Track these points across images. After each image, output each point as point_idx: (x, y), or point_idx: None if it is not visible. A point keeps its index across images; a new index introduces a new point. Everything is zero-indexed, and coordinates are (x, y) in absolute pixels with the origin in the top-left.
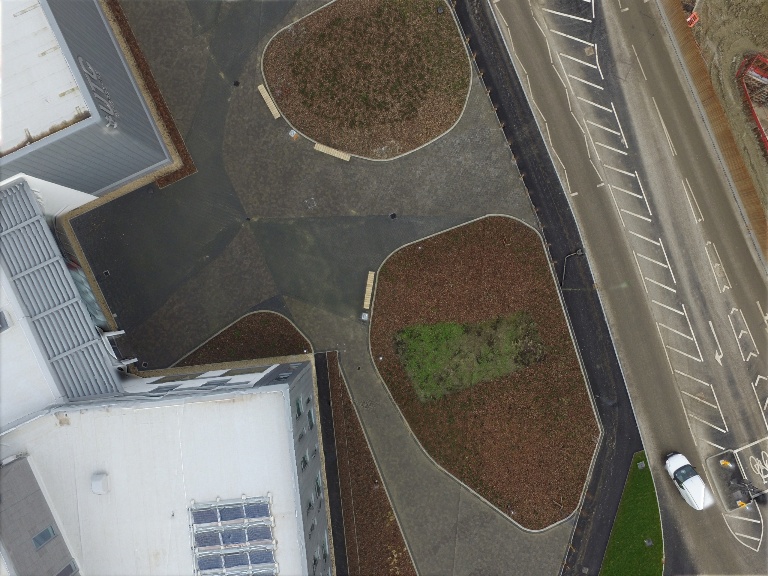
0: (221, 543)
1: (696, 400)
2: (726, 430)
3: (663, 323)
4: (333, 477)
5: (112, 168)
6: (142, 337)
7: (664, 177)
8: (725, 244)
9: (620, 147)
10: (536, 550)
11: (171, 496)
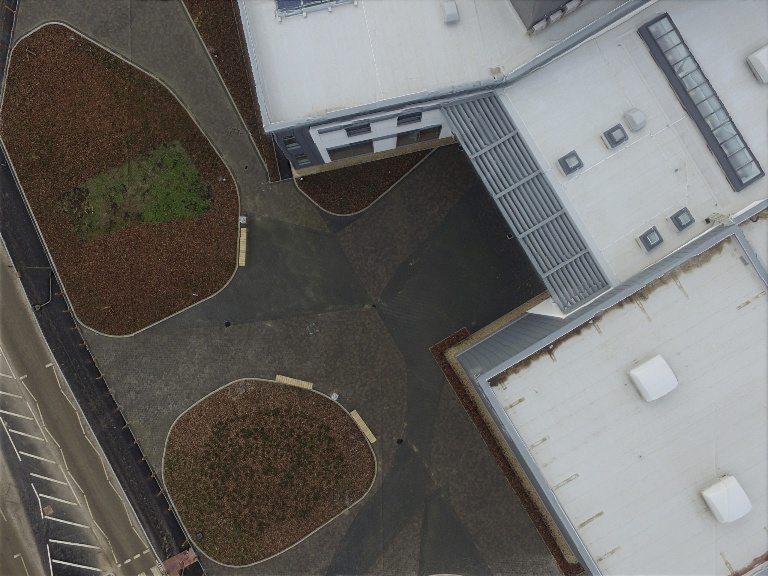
0: None
1: None
2: None
3: None
4: None
5: None
6: (467, 176)
7: None
8: None
9: (8, 417)
10: (49, 4)
11: (379, 7)
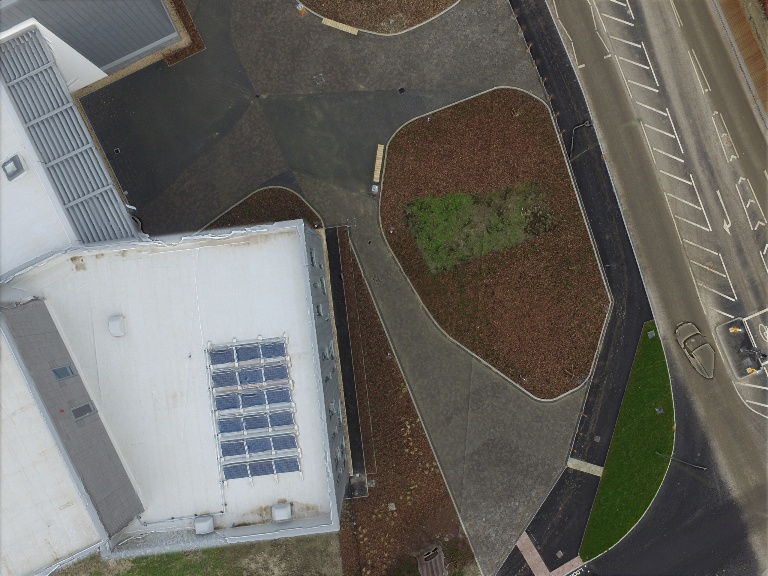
0: (238, 383)
1: (705, 269)
2: (735, 299)
3: (671, 193)
4: (345, 351)
5: (122, 33)
6: (153, 214)
7: (670, 48)
8: (732, 114)
9: (626, 18)
10: (548, 419)
11: (188, 338)
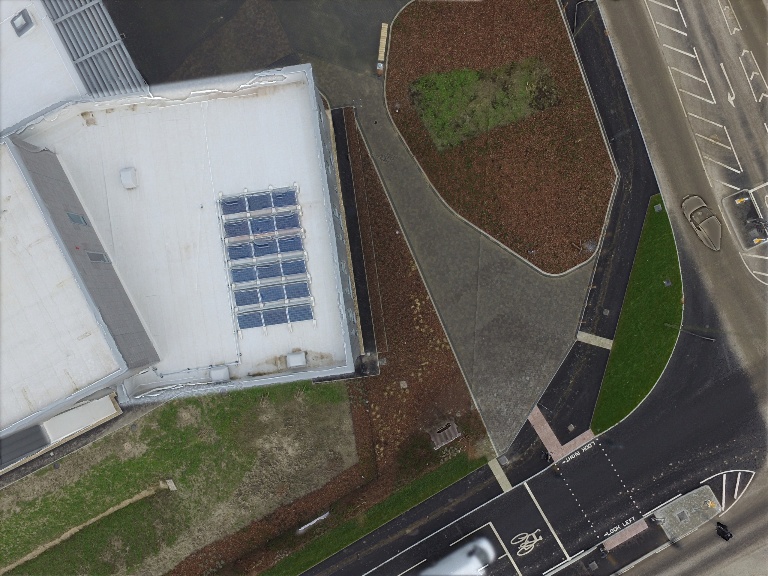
0: (250, 233)
1: (710, 142)
2: (741, 171)
3: (675, 67)
4: (354, 231)
5: None
6: None
7: None
8: None
9: None
10: (557, 294)
11: (199, 189)
